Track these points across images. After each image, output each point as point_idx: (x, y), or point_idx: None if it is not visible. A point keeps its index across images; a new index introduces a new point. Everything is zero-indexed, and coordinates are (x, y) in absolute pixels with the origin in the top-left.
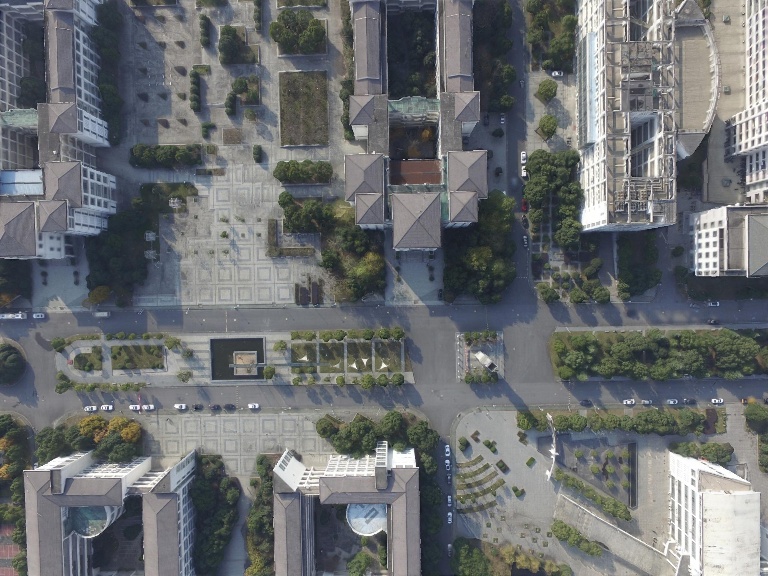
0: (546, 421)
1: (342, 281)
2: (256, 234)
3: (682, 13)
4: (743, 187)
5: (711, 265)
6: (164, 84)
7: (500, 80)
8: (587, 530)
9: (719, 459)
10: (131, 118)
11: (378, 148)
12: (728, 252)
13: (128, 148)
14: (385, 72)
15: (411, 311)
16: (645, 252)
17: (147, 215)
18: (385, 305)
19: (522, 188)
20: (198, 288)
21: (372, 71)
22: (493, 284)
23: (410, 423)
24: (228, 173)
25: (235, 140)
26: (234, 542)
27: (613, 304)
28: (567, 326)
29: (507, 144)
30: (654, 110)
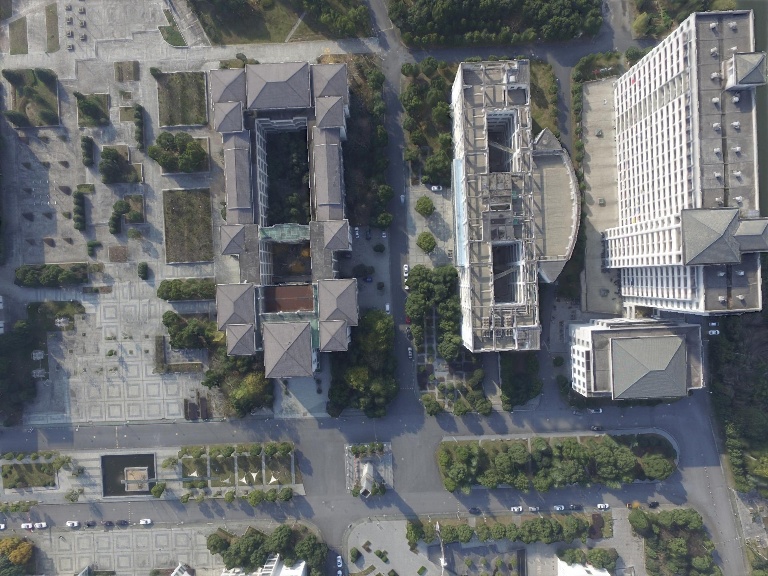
0: (433, 533)
1: (226, 401)
2: (144, 351)
3: (540, 144)
4: (620, 297)
5: (581, 384)
6: (49, 203)
7: (377, 199)
8: None
9: (605, 565)
10: (17, 238)
11: (250, 277)
12: (595, 374)
13: (14, 268)
14: (257, 199)
15: (300, 424)
16: (526, 363)
17: (35, 334)
18: (274, 418)
19: (405, 301)
20: (88, 405)
21: (242, 201)
22: (374, 401)
23: (302, 535)
24: (115, 291)
25: (121, 258)
26: None
27: (498, 412)
28: (454, 435)
29: (390, 257)
30: (515, 240)
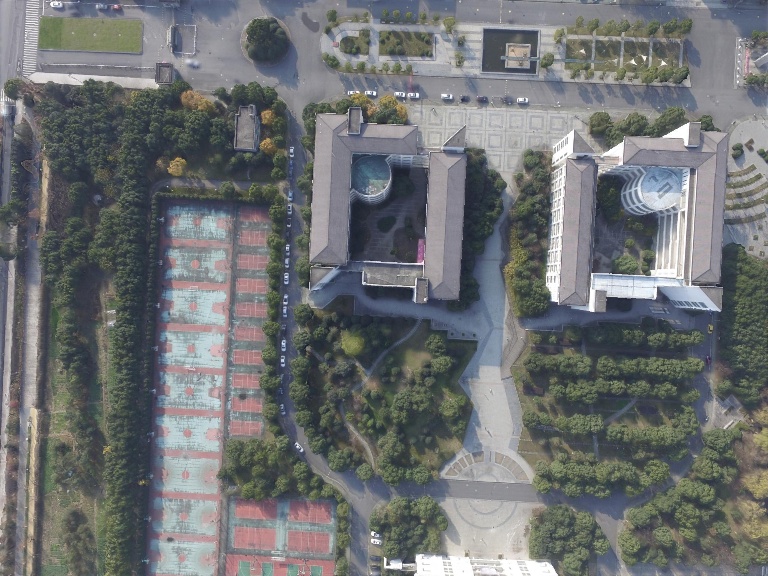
0: None
1: None
2: None
3: None
4: None
5: None
6: None
7: None
8: None
9: None
10: None
11: None
12: None
13: None
14: None
15: (693, 12)
16: None
17: None
18: (666, 5)
19: None
20: None
21: None
22: None
23: None
24: None
25: None
26: (491, 241)
27: None
28: None
29: None
30: None
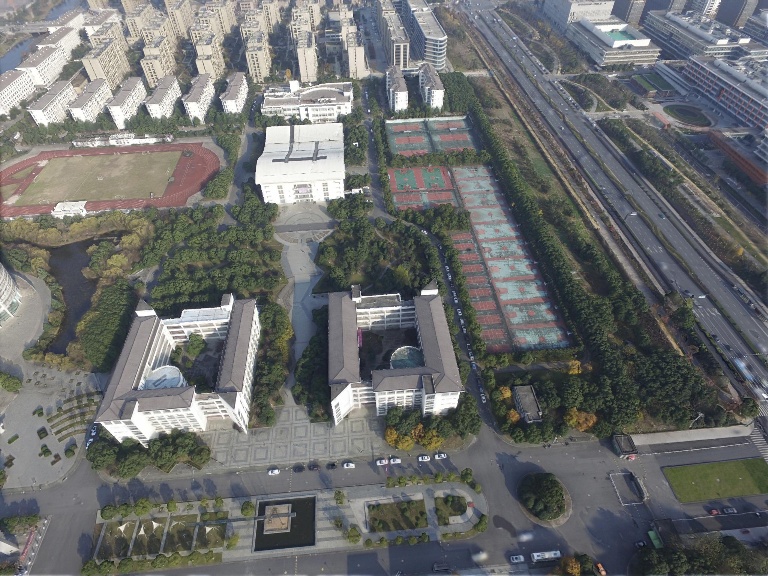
0: None
1: None
2: None
3: None
4: None
5: None
6: None
7: None
8: None
9: None
10: None
11: None
12: None
13: None
14: None
15: None
16: None
17: None
18: None
19: None
20: None
21: None
22: None
23: None
24: None
25: None
26: None
27: None
28: None
29: None
30: None
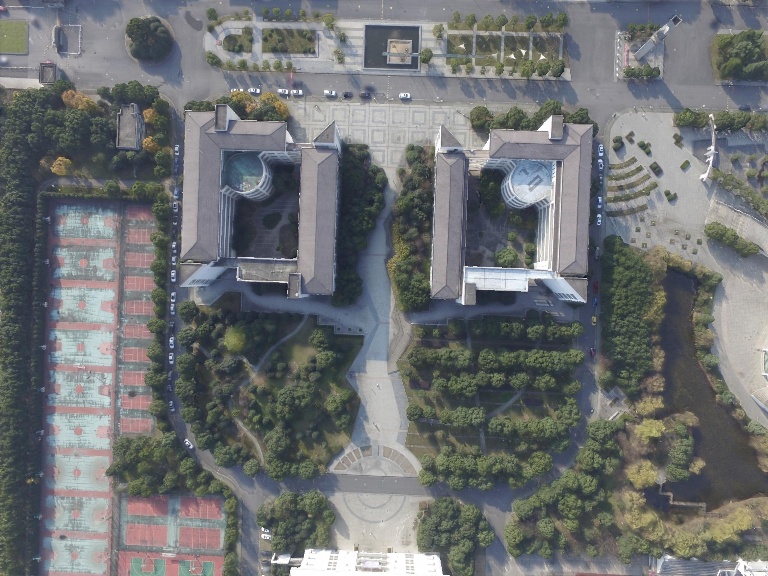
0: None
1: None
2: None
3: None
4: None
5: None
6: None
7: None
8: (742, 231)
9: None
10: None
11: None
12: None
13: None
14: None
15: (572, 6)
16: None
17: None
18: None
19: None
20: None
21: None
22: None
23: None
24: None
25: None
26: (376, 236)
27: None
28: (730, 29)
29: None
30: None
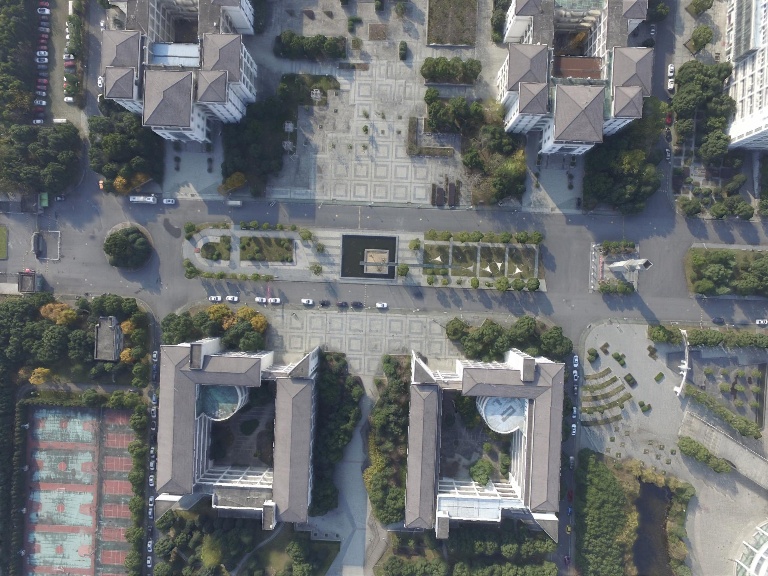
0: (681, 334)
1: (487, 179)
2: (396, 131)
3: None
4: None
5: None
6: None
7: None
8: (715, 447)
9: None
10: (277, 7)
11: (543, 40)
12: None
13: (272, 37)
14: None
15: (547, 218)
16: None
17: (287, 106)
18: (521, 211)
19: (668, 101)
20: (333, 183)
21: None
22: (639, 191)
23: None
24: (372, 68)
25: (381, 36)
26: (352, 443)
27: (751, 223)
28: (704, 242)
29: (655, 56)
30: None
